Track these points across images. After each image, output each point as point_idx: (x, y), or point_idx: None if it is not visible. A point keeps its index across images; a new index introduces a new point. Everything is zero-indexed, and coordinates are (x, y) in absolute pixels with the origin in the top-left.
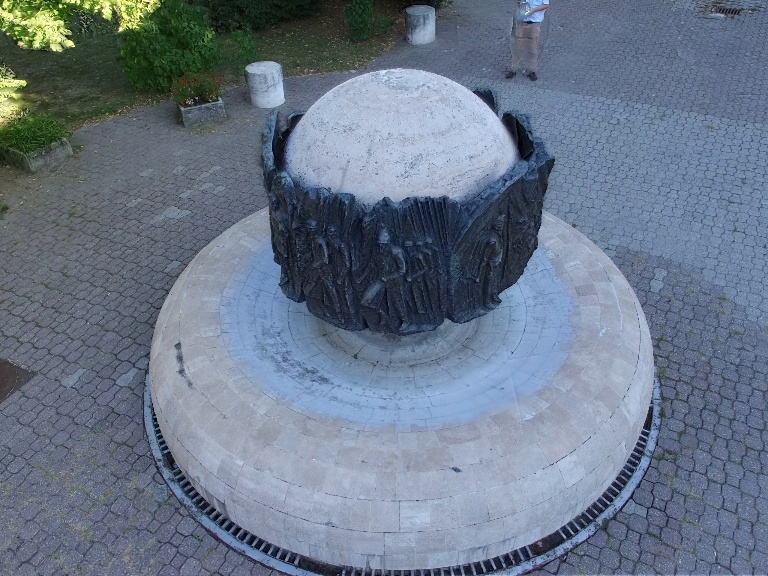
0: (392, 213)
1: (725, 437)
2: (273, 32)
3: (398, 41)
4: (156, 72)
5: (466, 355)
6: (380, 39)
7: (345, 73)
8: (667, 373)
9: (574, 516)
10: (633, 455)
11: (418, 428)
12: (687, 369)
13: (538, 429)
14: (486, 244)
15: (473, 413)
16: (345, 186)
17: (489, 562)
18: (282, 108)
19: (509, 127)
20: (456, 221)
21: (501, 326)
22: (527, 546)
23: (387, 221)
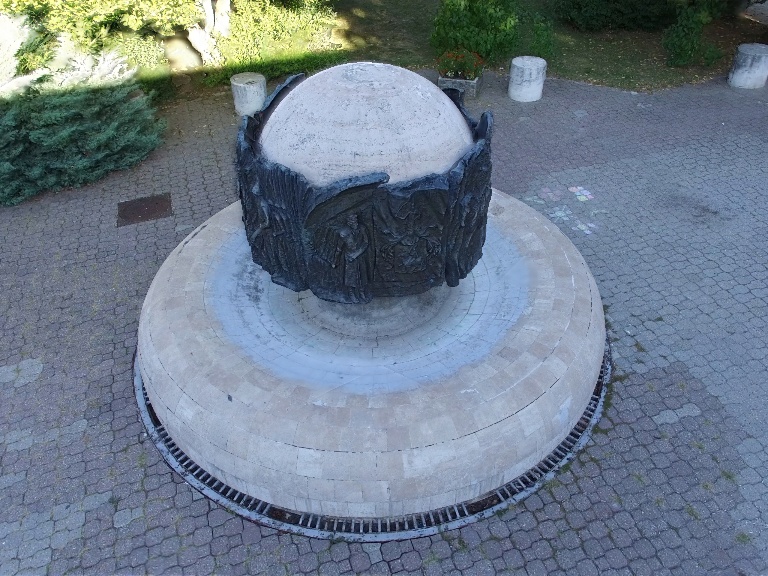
0: (263, 171)
1: (531, 574)
2: (605, 36)
3: (719, 77)
4: (450, 42)
5: (368, 345)
6: (700, 70)
7: (624, 92)
8: (556, 488)
9: (313, 511)
10: (430, 519)
11: (249, 359)
12: (582, 500)
13: (312, 415)
14: (339, 235)
15: (295, 376)
16: (266, 140)
17: (237, 493)
18: (528, 105)
19: (463, 152)
20: (304, 199)
21: (421, 342)
22: (269, 504)
23: (259, 176)
